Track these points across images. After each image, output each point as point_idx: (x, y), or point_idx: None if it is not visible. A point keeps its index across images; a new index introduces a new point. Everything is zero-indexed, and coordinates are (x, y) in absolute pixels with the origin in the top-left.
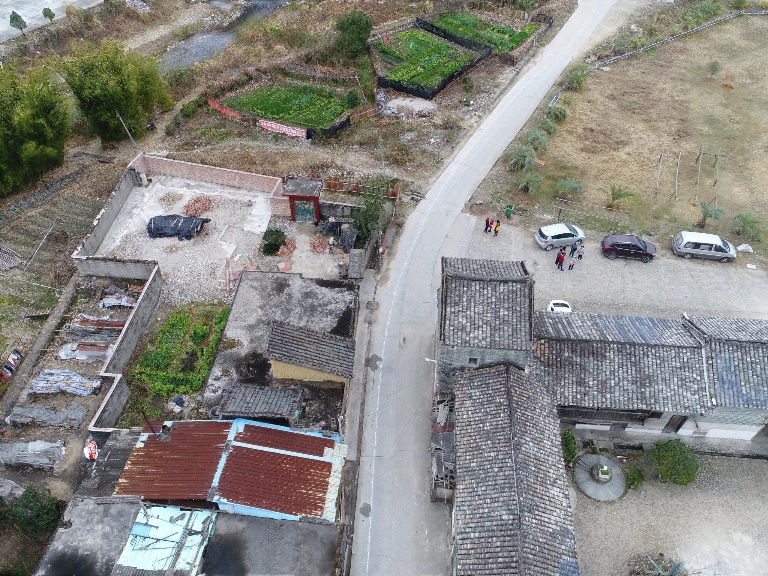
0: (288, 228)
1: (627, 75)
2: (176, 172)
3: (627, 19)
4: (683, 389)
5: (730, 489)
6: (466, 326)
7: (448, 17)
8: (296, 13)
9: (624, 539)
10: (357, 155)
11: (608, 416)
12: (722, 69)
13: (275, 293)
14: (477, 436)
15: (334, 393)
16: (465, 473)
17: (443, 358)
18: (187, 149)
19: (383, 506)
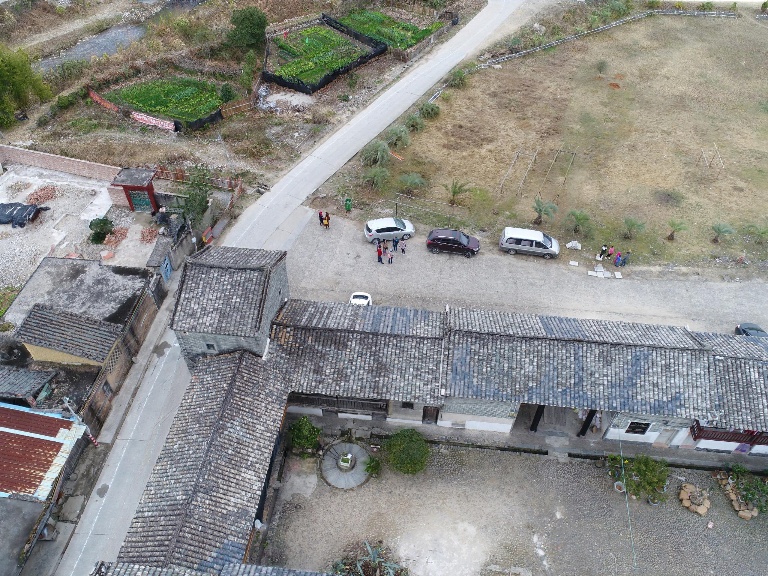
0: (125, 218)
1: (517, 73)
2: (31, 161)
3: (532, 17)
4: (417, 379)
5: (472, 480)
6: (196, 312)
7: (357, 14)
8: (214, 9)
9: (349, 526)
10: (217, 148)
11: (350, 405)
12: (615, 68)
13: (68, 279)
14: (190, 419)
15: (88, 376)
16: (166, 455)
17: (181, 343)
18: (53, 139)
19: (121, 487)
